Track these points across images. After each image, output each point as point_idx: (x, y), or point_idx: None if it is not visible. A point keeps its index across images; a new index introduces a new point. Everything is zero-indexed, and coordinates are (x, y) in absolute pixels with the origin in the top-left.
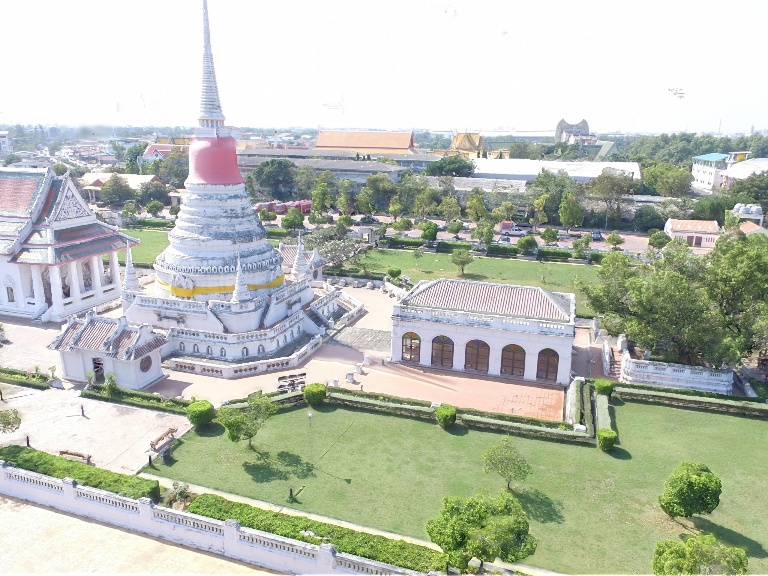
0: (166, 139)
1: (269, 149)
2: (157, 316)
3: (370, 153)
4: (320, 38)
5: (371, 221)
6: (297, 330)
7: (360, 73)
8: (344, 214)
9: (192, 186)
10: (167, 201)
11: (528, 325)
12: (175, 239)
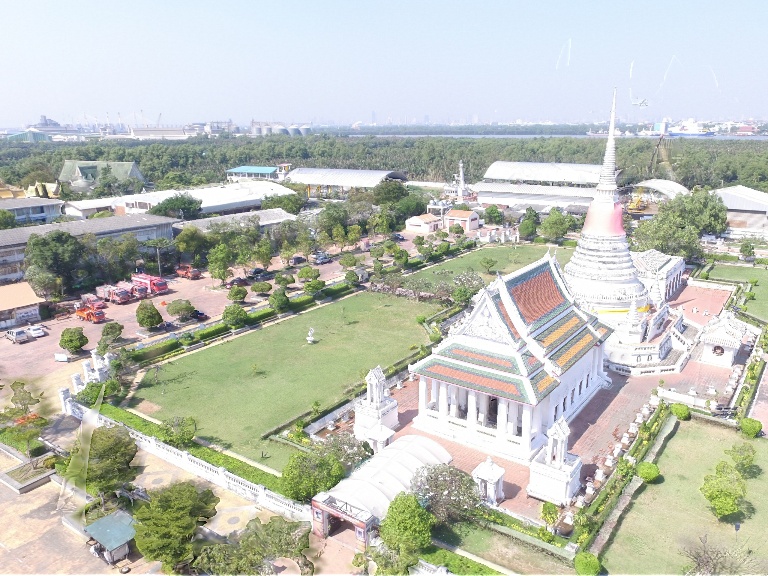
0: None
1: None
2: None
3: None
4: None
5: None
6: None
7: None
8: (245, 272)
9: None
10: None
11: None
12: None
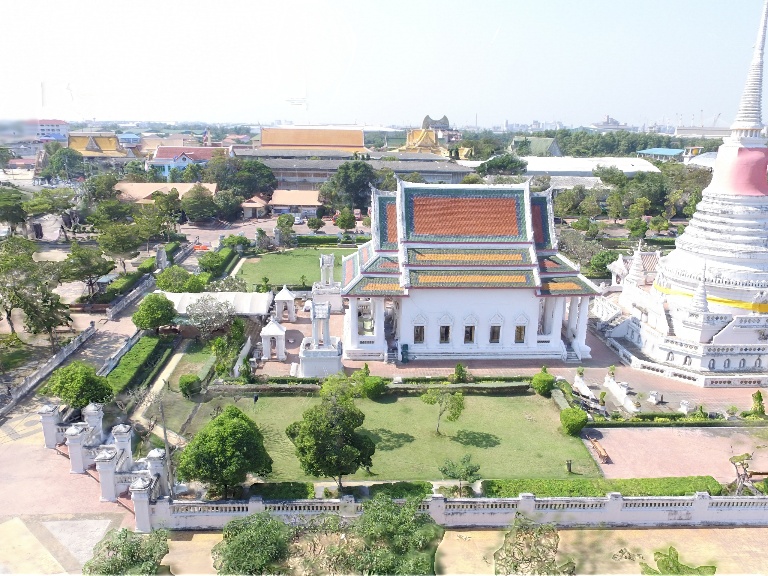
0: (83, 138)
1: (246, 149)
2: (762, 335)
3: (362, 152)
4: (281, 28)
5: None
6: None
7: (323, 67)
8: None
9: (749, 198)
10: (235, 213)
11: None
12: (740, 254)
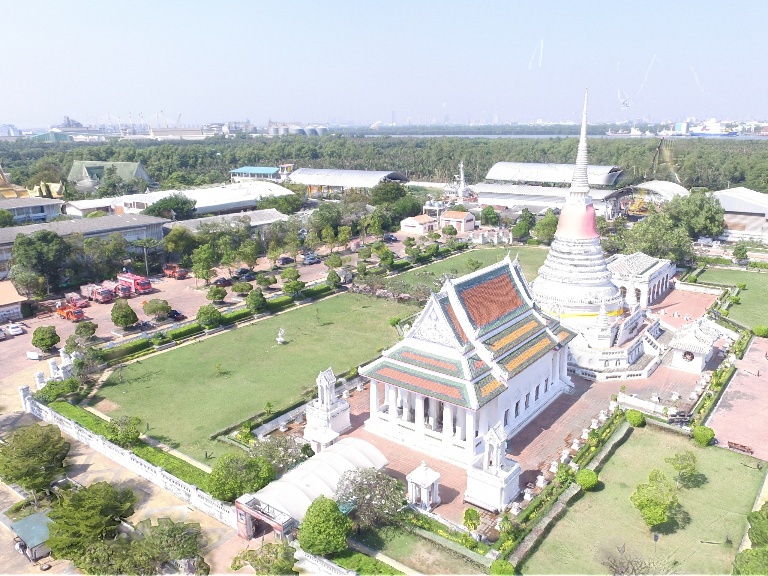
0: None
1: None
2: None
3: None
4: None
5: (255, 272)
6: None
7: None
8: (229, 272)
9: None
10: None
11: (665, 266)
12: None
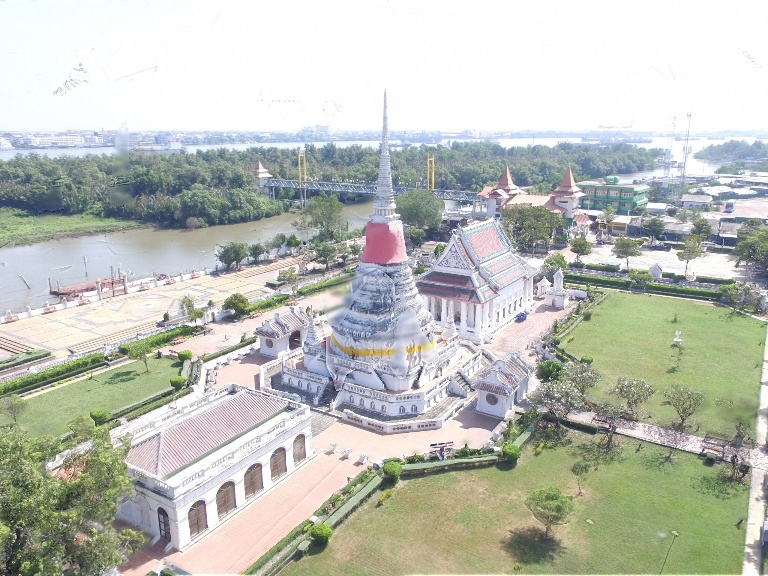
0: None
1: None
2: None
3: None
4: None
5: None
6: (319, 389)
7: None
8: None
9: None
10: None
11: None
12: None
